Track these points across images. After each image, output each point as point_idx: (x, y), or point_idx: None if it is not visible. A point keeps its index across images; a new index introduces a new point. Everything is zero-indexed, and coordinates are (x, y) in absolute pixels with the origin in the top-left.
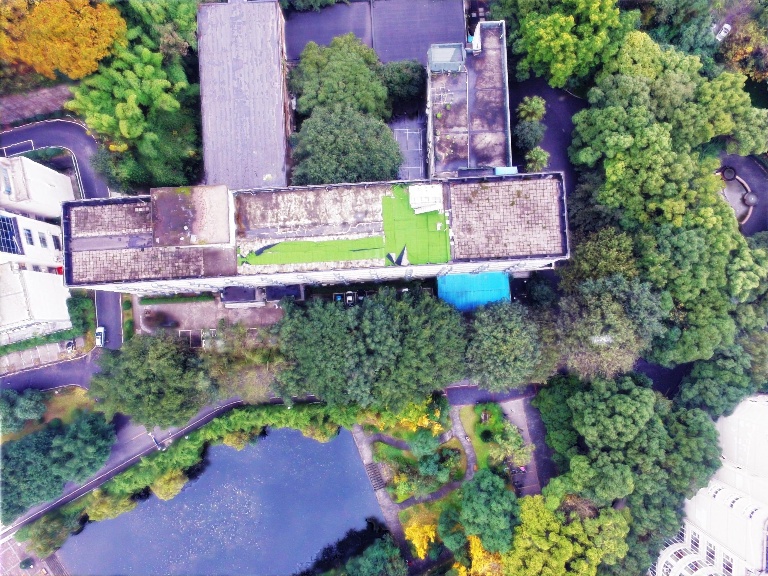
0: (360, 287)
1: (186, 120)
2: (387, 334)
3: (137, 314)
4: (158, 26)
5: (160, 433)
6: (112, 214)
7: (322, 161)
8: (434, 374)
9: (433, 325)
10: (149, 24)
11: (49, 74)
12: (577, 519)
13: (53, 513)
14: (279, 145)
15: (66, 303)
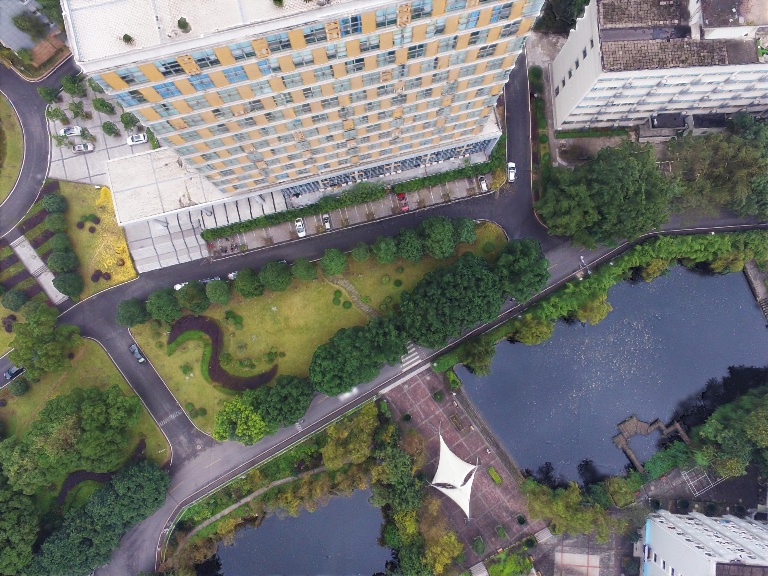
0: None
1: None
2: None
3: (553, 147)
4: None
5: (571, 265)
6: (638, 7)
7: None
8: None
9: None
10: None
11: None
12: None
13: (474, 341)
14: None
15: None
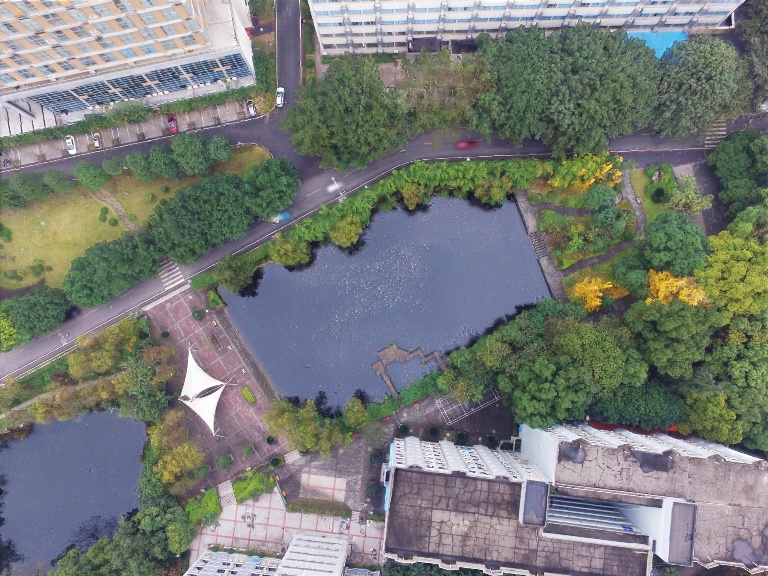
0: None
1: None
2: (595, 50)
3: (319, 72)
4: None
5: (334, 190)
6: None
7: None
8: (629, 104)
9: (632, 53)
10: None
11: None
12: None
13: None
14: None
15: (252, 59)
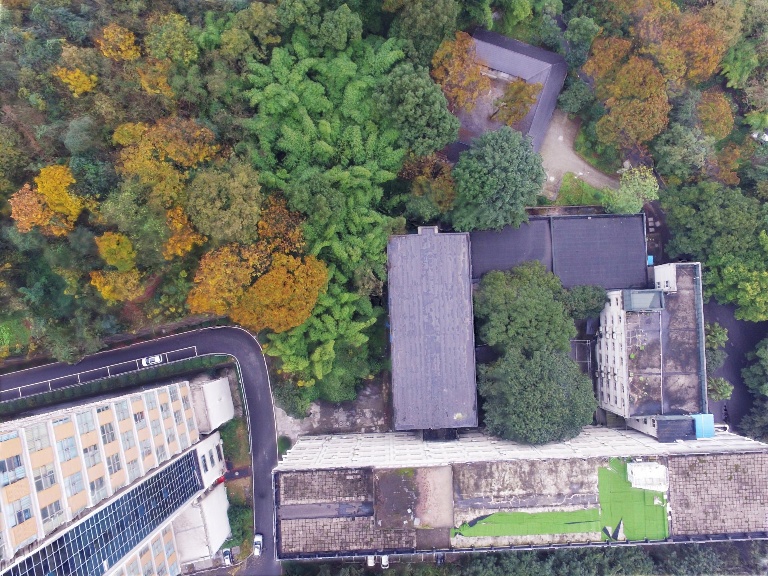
0: None
1: None
2: None
3: None
4: (354, 265)
5: None
6: (322, 481)
7: (527, 417)
8: None
9: None
10: (344, 262)
11: (254, 328)
12: None
13: None
14: (470, 383)
15: (227, 514)
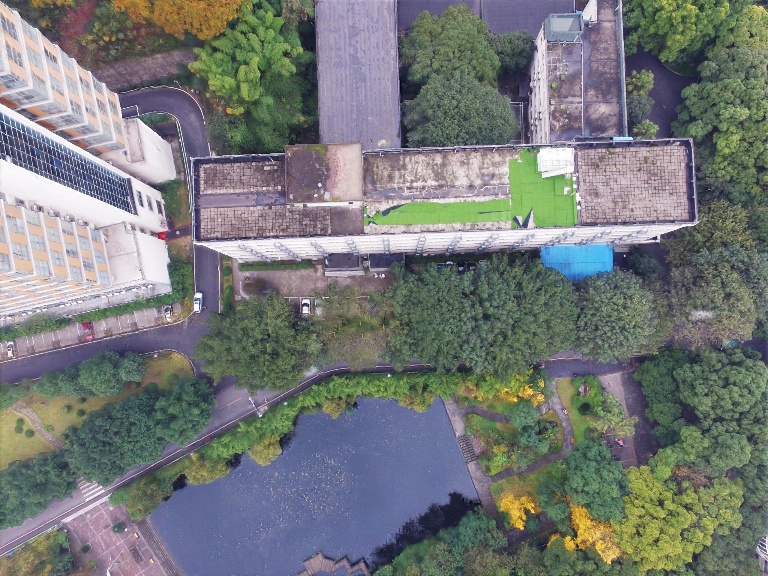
0: (460, 258)
1: (294, 88)
2: (505, 299)
3: (237, 280)
4: None
5: (256, 400)
6: (241, 172)
7: (444, 126)
8: (546, 342)
9: (547, 292)
10: None
11: (178, 34)
12: (690, 489)
13: (149, 477)
14: (394, 111)
15: (167, 268)
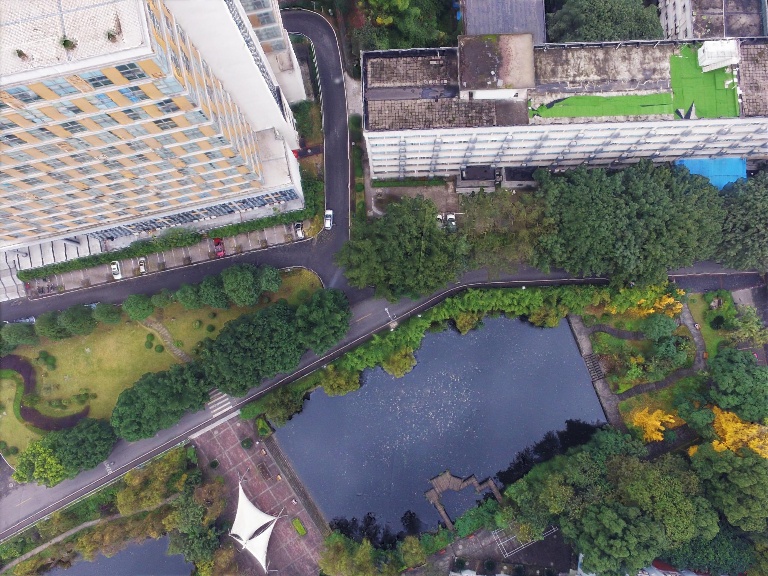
0: None
1: (431, 7)
2: (661, 195)
3: (369, 196)
4: None
5: (385, 315)
6: (407, 66)
7: (598, 28)
8: None
9: (696, 194)
10: None
11: None
12: None
13: None
14: (539, 22)
15: (301, 183)
